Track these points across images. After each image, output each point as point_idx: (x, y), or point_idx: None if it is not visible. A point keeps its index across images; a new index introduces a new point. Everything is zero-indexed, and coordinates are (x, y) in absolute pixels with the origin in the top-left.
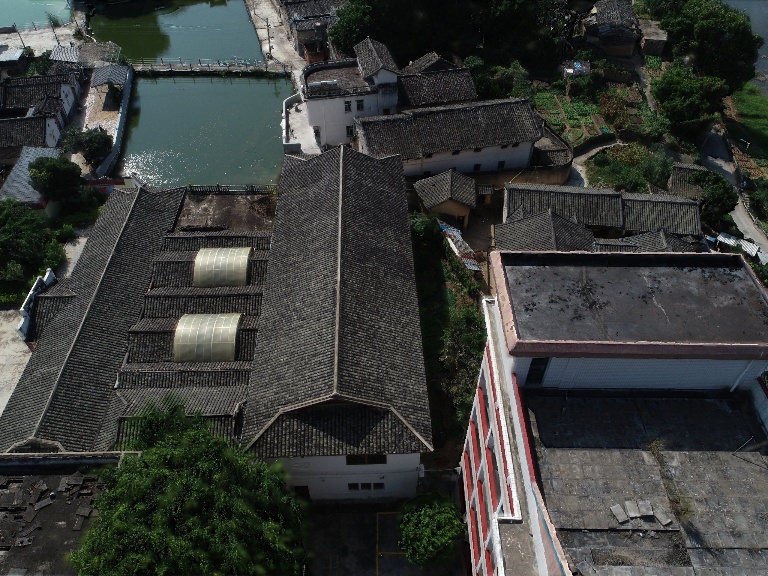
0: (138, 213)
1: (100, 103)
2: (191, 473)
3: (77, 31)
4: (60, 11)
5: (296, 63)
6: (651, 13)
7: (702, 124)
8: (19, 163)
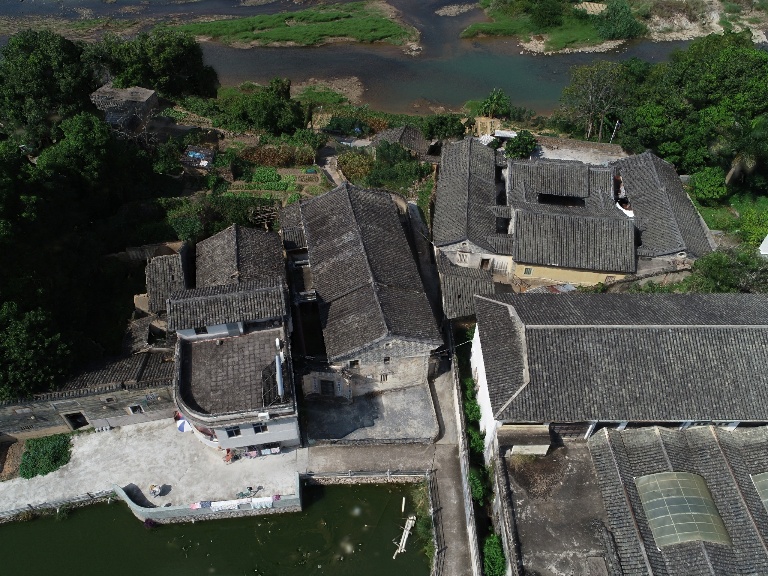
0: None
1: None
2: None
3: None
4: None
5: None
6: None
7: (308, 116)
8: None
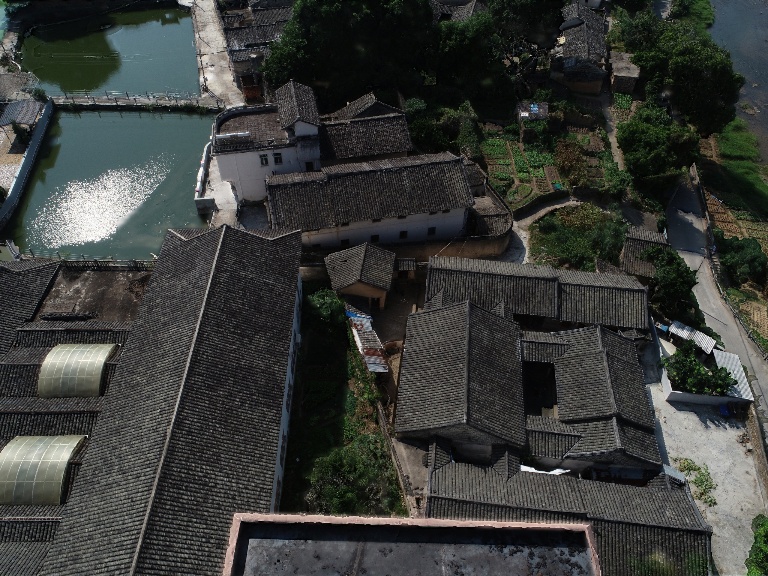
0: None
1: (8, 143)
2: None
3: (2, 56)
4: None
5: (232, 97)
6: (625, 43)
7: (668, 179)
8: None
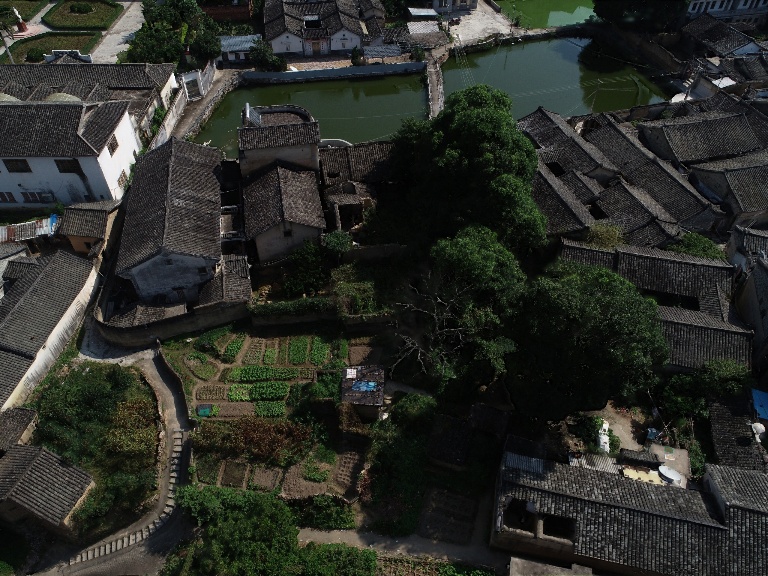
0: (121, 68)
1: None
2: None
3: None
4: None
5: None
6: None
7: None
8: (239, 37)
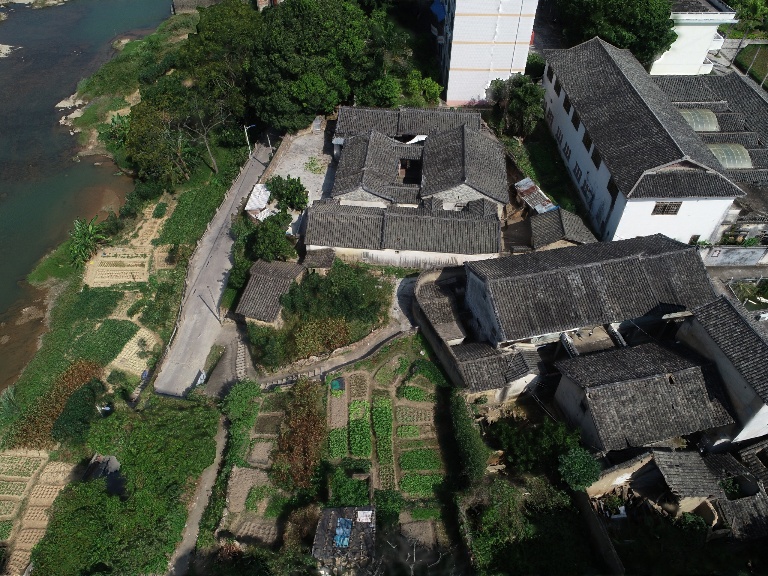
0: None
1: None
2: (640, 5)
3: None
4: None
5: None
6: None
7: None
8: None
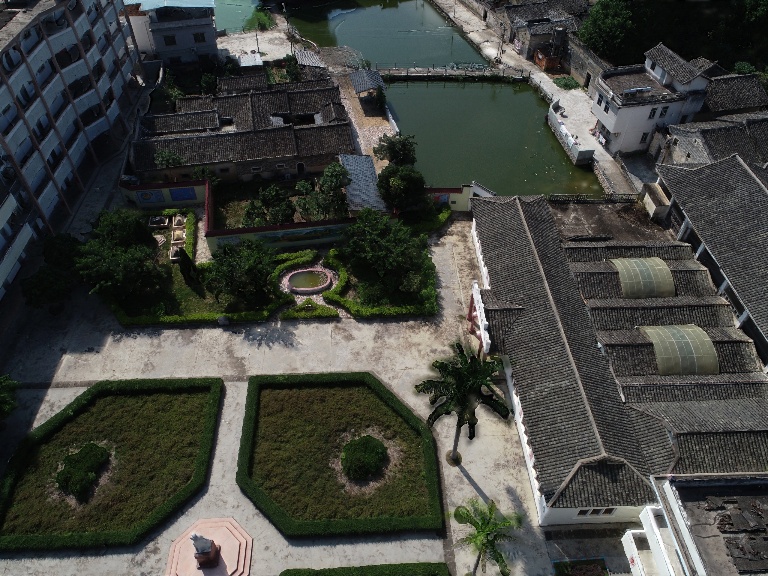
0: (530, 223)
1: (359, 108)
2: None
3: None
4: (252, 14)
5: (528, 67)
6: None
7: None
8: None
